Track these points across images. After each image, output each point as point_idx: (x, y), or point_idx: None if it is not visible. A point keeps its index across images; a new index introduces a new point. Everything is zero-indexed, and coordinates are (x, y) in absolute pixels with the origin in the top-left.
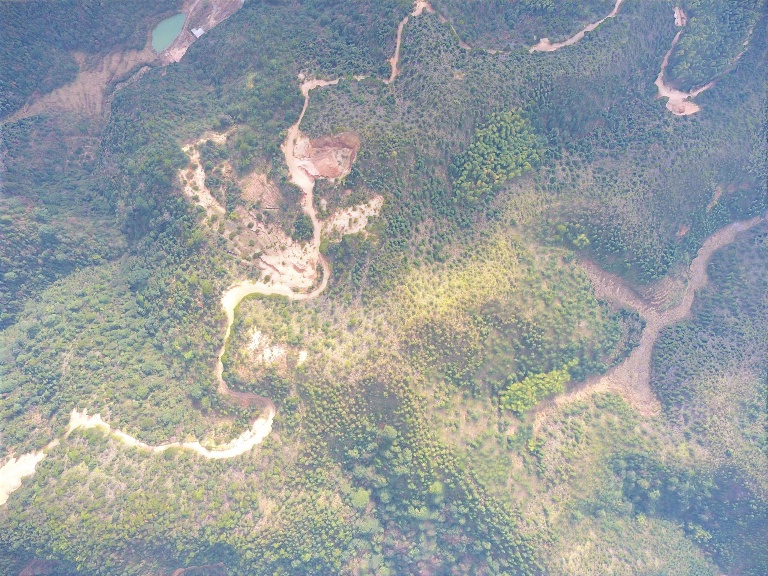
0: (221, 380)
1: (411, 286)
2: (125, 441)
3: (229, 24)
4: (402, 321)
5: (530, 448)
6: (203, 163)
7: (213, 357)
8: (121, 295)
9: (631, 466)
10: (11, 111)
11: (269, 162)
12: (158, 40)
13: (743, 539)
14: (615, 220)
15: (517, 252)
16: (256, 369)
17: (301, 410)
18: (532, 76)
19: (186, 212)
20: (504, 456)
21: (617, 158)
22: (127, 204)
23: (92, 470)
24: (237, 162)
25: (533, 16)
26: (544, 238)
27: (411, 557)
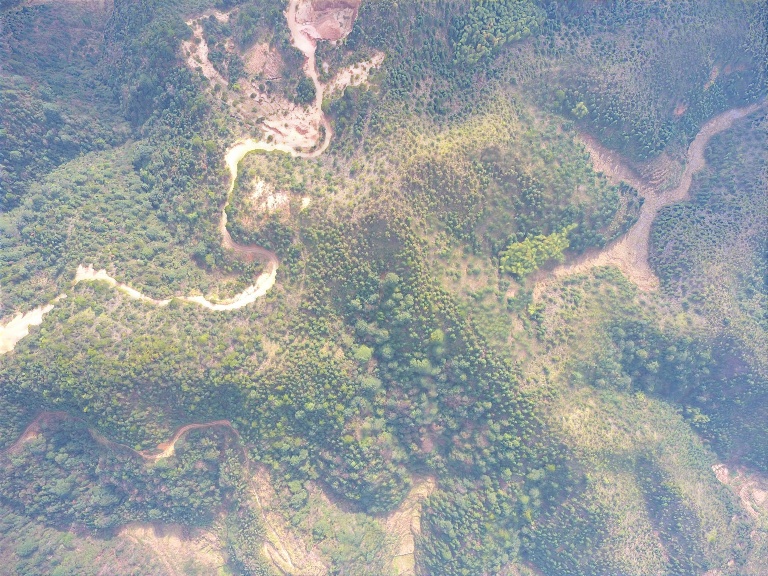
0: (225, 235)
1: (412, 129)
2: (130, 294)
3: None
4: (404, 159)
5: (530, 311)
6: (206, 37)
7: (217, 212)
8: (125, 174)
9: (630, 336)
10: (15, 1)
11: (271, 30)
12: None
13: (741, 421)
14: (613, 88)
15: (517, 109)
16: (260, 217)
17: (304, 257)
18: None
19: (189, 83)
20: (504, 314)
21: (615, 32)
22: None
23: (98, 315)
24: (240, 35)
25: None
26: (543, 103)
27: (413, 419)
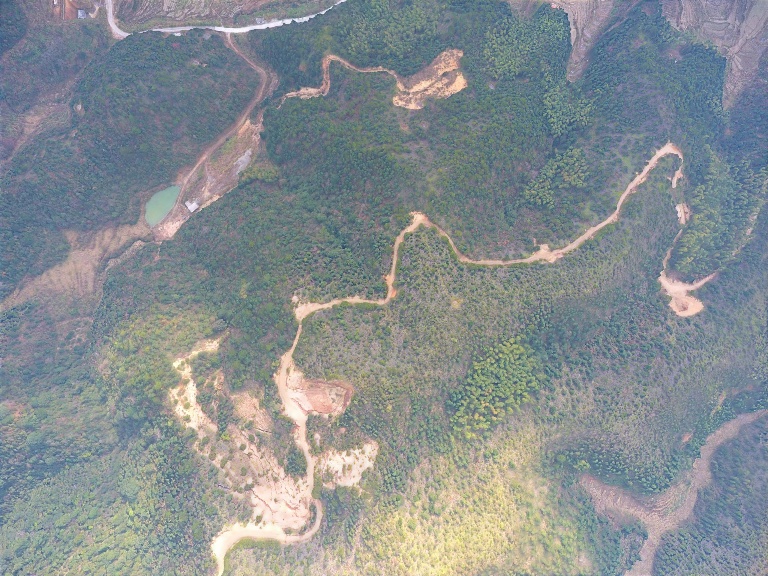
0: None
1: (406, 557)
2: None
3: (223, 208)
4: None
5: None
6: (195, 378)
7: None
8: (111, 503)
9: None
10: (1, 298)
11: (262, 387)
12: (151, 213)
13: None
14: (616, 445)
15: (515, 498)
16: None
17: None
18: (531, 300)
19: (177, 433)
20: None
21: (618, 373)
22: (118, 405)
23: None
24: (229, 379)
25: (533, 210)
26: (543, 469)
27: None
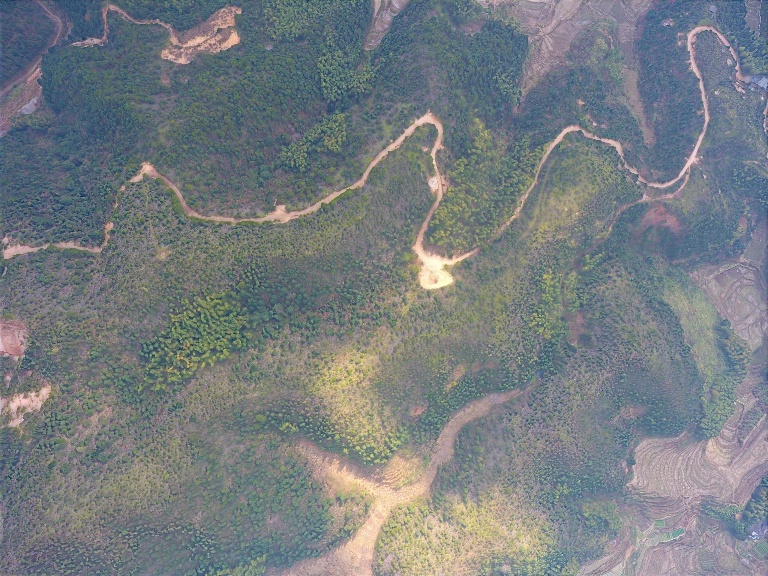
0: None
1: (45, 499)
2: None
3: None
4: (23, 541)
5: None
6: None
7: None
8: None
9: None
10: None
11: None
12: None
13: None
14: (323, 410)
15: (192, 452)
16: None
17: None
18: (243, 257)
19: None
20: None
21: (341, 339)
22: None
23: None
24: None
25: (288, 173)
26: (240, 428)
27: None
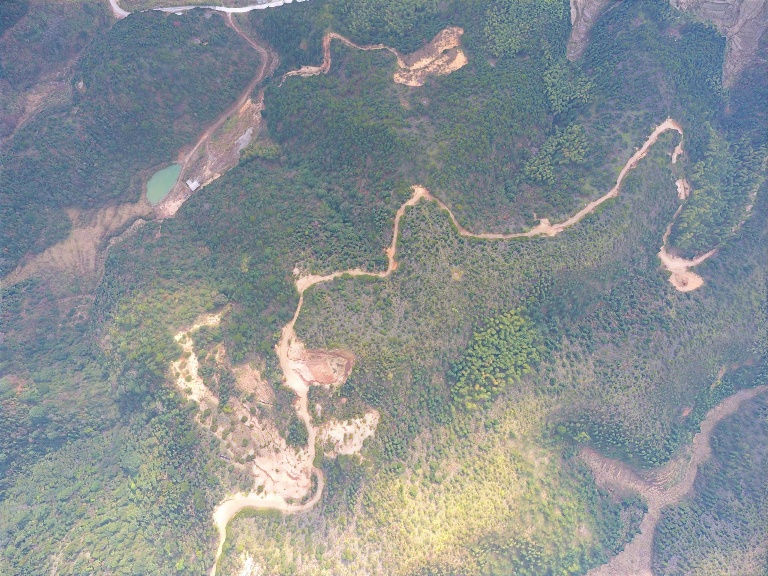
0: None
1: (407, 523)
2: None
3: (224, 186)
4: (397, 566)
5: None
6: (196, 351)
7: (204, 575)
8: (113, 477)
9: None
10: (3, 275)
11: (263, 359)
12: (153, 192)
13: None
14: (616, 417)
15: (516, 467)
16: None
17: None
18: (532, 272)
19: (178, 405)
20: None
21: (619, 346)
22: (119, 380)
23: None
24: (231, 352)
25: (533, 186)
26: (544, 440)
27: None
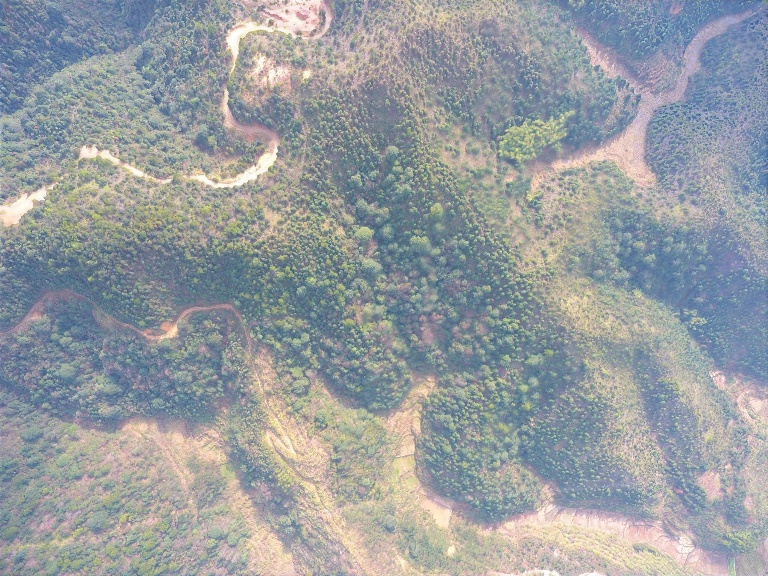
0: (227, 114)
1: None
2: (134, 172)
3: None
4: (403, 25)
5: (528, 198)
6: None
7: (219, 92)
8: (127, 73)
9: (627, 228)
10: None
11: None
12: None
13: (737, 323)
14: None
15: None
16: (261, 92)
17: (305, 131)
18: None
19: None
20: (503, 196)
21: None
22: None
23: (102, 187)
24: None
25: None
26: None
27: (413, 304)
